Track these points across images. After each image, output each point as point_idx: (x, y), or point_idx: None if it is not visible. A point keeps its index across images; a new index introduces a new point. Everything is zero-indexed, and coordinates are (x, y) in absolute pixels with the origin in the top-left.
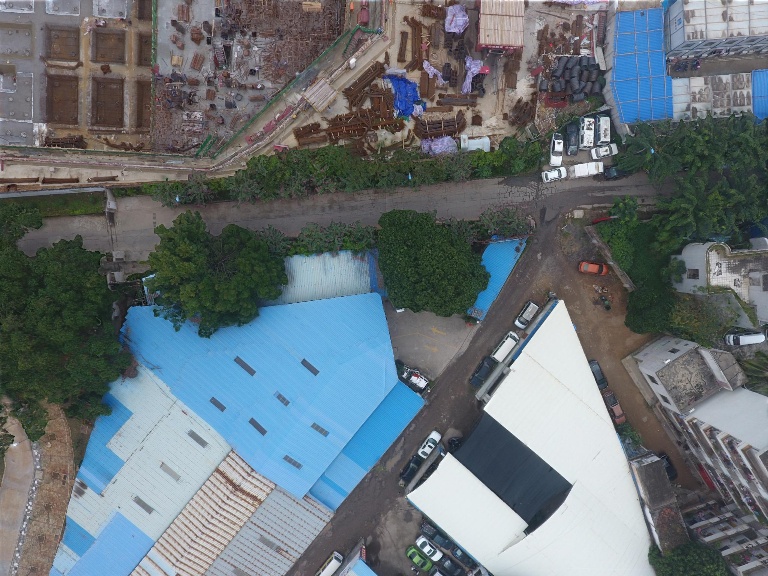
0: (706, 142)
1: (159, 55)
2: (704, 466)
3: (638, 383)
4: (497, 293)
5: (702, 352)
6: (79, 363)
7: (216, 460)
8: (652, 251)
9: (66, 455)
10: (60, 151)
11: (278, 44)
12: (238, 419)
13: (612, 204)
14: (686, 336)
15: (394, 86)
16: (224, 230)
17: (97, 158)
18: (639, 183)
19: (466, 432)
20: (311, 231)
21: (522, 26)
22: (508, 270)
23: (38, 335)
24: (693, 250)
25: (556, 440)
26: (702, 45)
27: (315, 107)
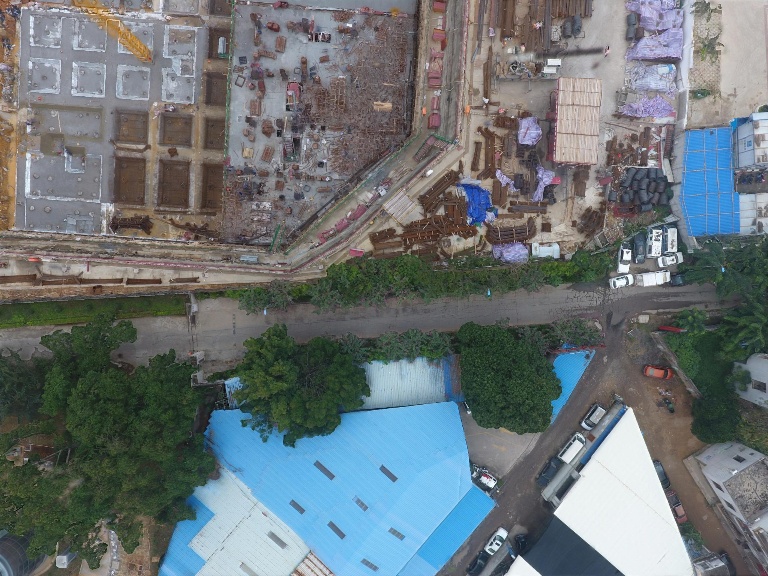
0: None
1: (231, 147)
2: (765, 568)
3: (699, 483)
4: (566, 398)
5: None
6: (175, 479)
7: (294, 561)
8: (717, 359)
9: (142, 546)
10: (138, 245)
11: (346, 138)
12: (317, 522)
13: (676, 309)
14: (750, 444)
15: (468, 194)
16: (310, 343)
17: (173, 252)
18: (703, 289)
19: (531, 529)
20: (390, 339)
21: (597, 145)
22: (578, 376)
23: (140, 456)
24: (760, 363)
25: (623, 544)
26: None
27: (394, 218)
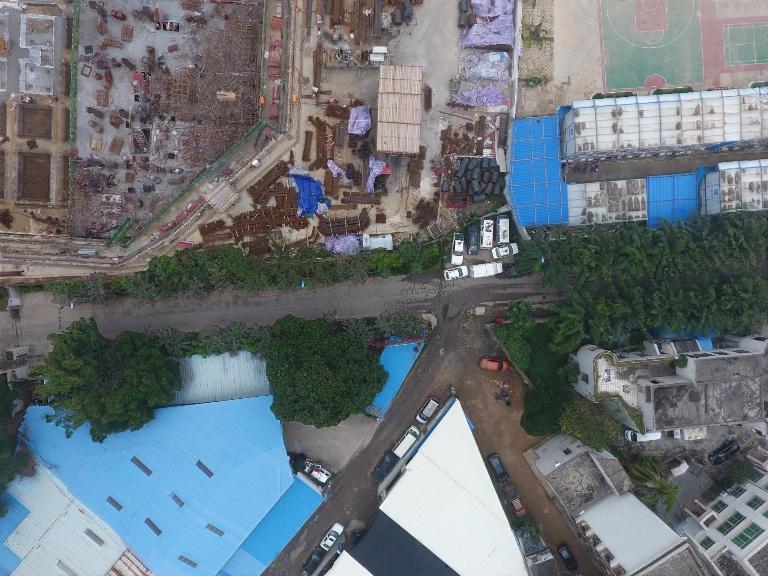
0: (595, 252)
1: (78, 138)
2: (599, 561)
3: (539, 476)
4: (396, 392)
5: (591, 456)
6: None
7: (112, 558)
8: (549, 350)
9: None
10: None
11: (197, 128)
12: (134, 519)
13: None
14: None
15: (298, 185)
16: (117, 337)
17: (10, 246)
18: (540, 281)
19: None
20: (209, 333)
21: (418, 134)
22: (407, 369)
23: None
24: (584, 355)
25: (451, 538)
26: (596, 153)
27: (216, 209)
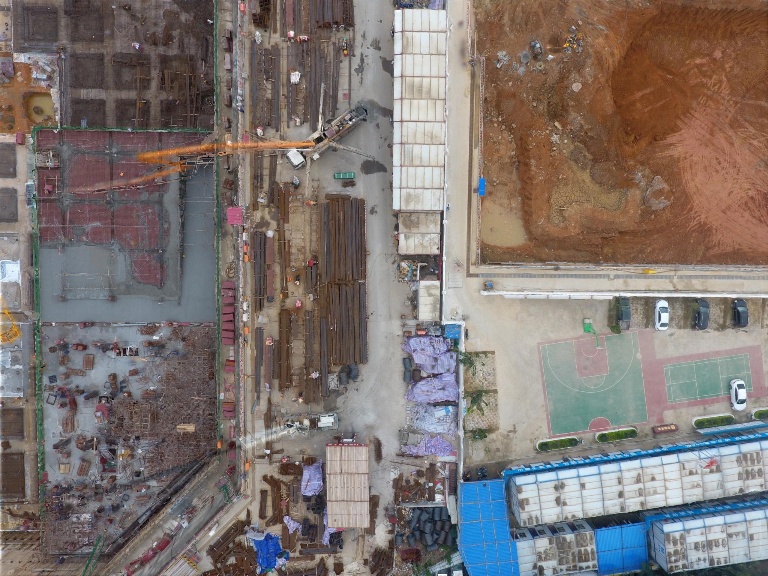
0: None
1: (47, 463)
2: None
3: None
4: None
5: None
6: None
7: None
8: None
9: None
10: None
11: (161, 446)
12: None
13: None
14: None
15: (256, 544)
16: None
17: None
18: None
19: None
20: None
21: (367, 510)
22: None
23: None
24: None
25: None
26: None
27: None
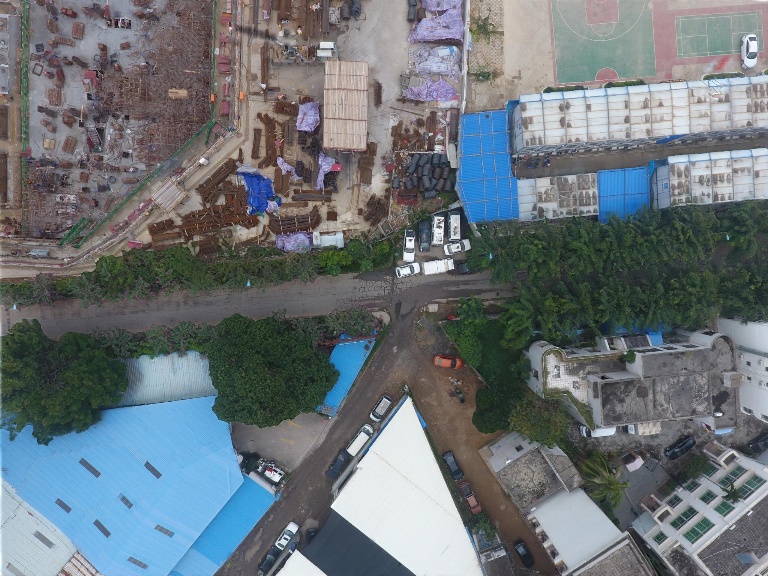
0: (542, 248)
1: (31, 138)
2: None
3: (495, 473)
4: (347, 390)
5: (542, 453)
6: None
7: (62, 560)
8: (502, 347)
9: None
10: None
11: (151, 127)
12: (83, 520)
13: (467, 297)
14: None
15: (247, 183)
16: (61, 338)
17: None
18: None
19: None
20: (157, 333)
21: (365, 130)
22: (358, 367)
23: None
24: (535, 351)
25: (404, 536)
26: (545, 148)
27: (163, 208)
